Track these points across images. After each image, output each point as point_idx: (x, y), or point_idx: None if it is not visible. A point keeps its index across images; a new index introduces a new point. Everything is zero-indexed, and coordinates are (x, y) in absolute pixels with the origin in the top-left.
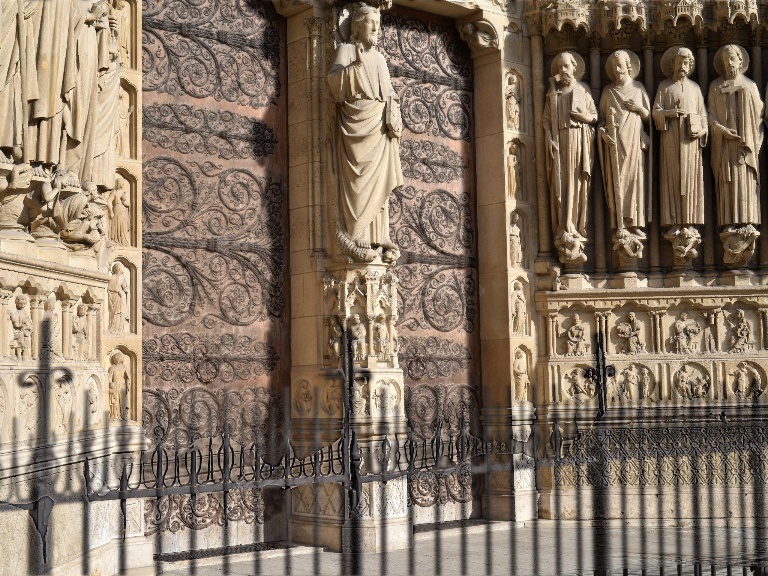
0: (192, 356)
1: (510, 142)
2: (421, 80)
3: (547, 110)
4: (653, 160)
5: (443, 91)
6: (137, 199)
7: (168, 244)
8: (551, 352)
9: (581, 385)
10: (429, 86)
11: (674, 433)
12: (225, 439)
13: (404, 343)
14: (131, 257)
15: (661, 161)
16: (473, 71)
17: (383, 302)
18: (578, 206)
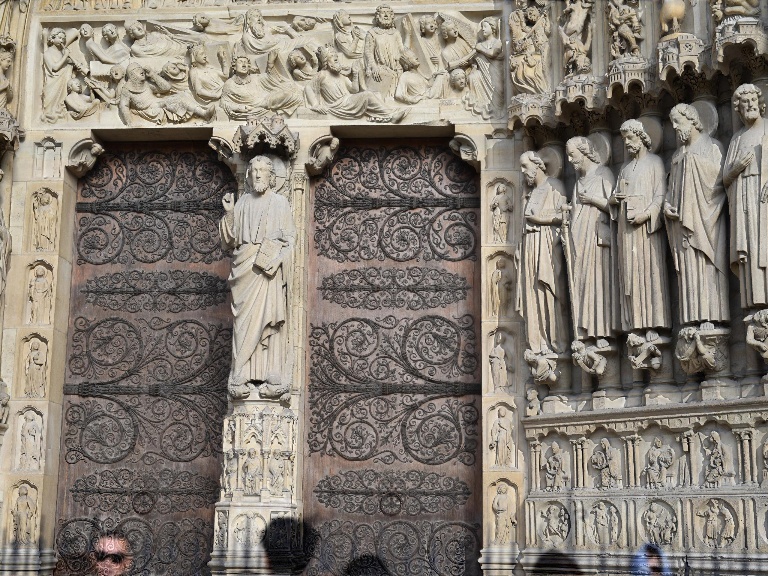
0: (129, 490)
1: (497, 256)
2: (407, 207)
3: None
4: None
5: (438, 213)
6: (48, 358)
7: (112, 392)
8: (533, 486)
9: (555, 525)
10: (420, 211)
11: None
12: None
13: (375, 477)
14: (39, 406)
15: None
16: None
17: (256, 437)
18: (546, 319)
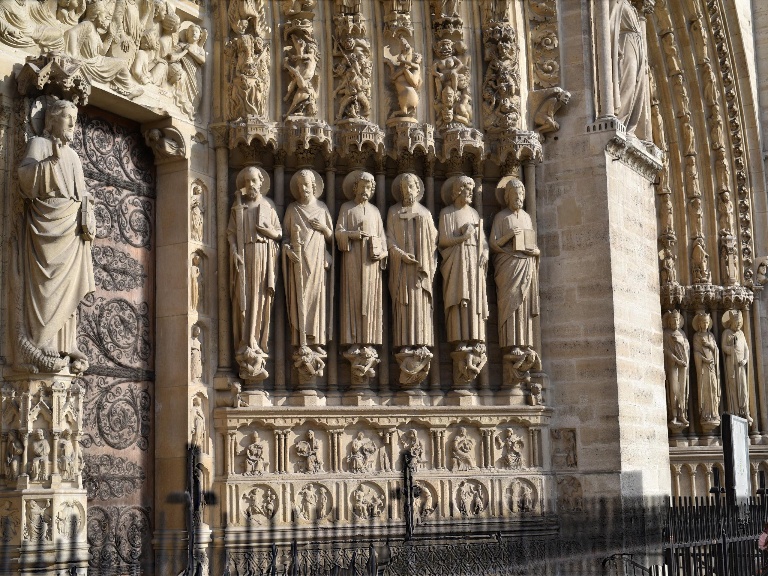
0: None
1: (193, 253)
2: (105, 183)
3: (232, 223)
4: (334, 279)
5: (126, 196)
6: None
7: None
8: (229, 471)
9: (259, 505)
10: (112, 189)
11: (350, 554)
12: (73, 575)
13: None
14: None
15: (342, 281)
16: (156, 178)
17: (69, 416)
18: (261, 321)
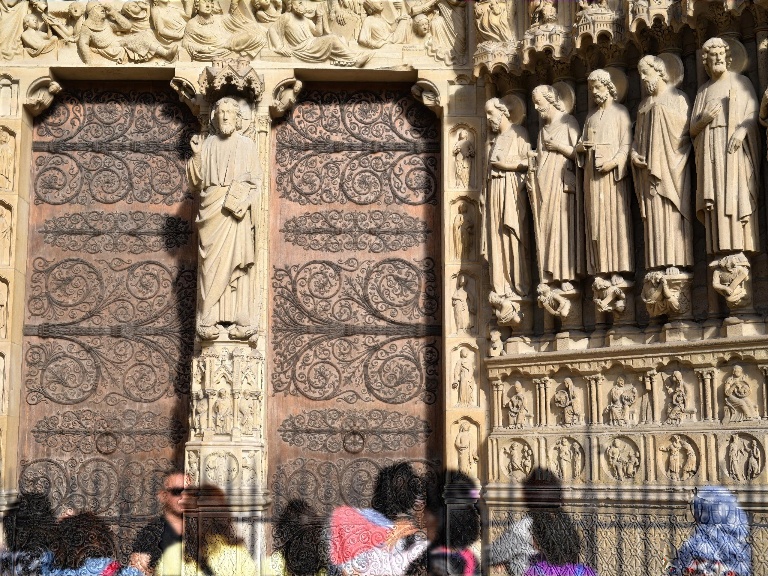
0: (92, 430)
1: (459, 201)
2: (368, 151)
3: None
4: None
5: (399, 158)
6: (9, 299)
7: (73, 333)
8: (495, 424)
9: (518, 461)
10: (381, 155)
11: (603, 520)
12: None
13: (339, 416)
14: (1, 347)
15: None
16: (440, 131)
17: (227, 377)
18: (510, 262)
